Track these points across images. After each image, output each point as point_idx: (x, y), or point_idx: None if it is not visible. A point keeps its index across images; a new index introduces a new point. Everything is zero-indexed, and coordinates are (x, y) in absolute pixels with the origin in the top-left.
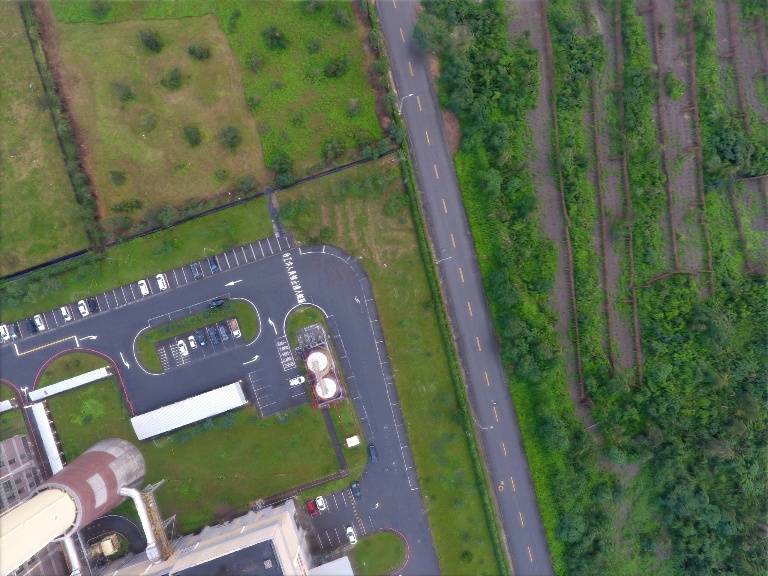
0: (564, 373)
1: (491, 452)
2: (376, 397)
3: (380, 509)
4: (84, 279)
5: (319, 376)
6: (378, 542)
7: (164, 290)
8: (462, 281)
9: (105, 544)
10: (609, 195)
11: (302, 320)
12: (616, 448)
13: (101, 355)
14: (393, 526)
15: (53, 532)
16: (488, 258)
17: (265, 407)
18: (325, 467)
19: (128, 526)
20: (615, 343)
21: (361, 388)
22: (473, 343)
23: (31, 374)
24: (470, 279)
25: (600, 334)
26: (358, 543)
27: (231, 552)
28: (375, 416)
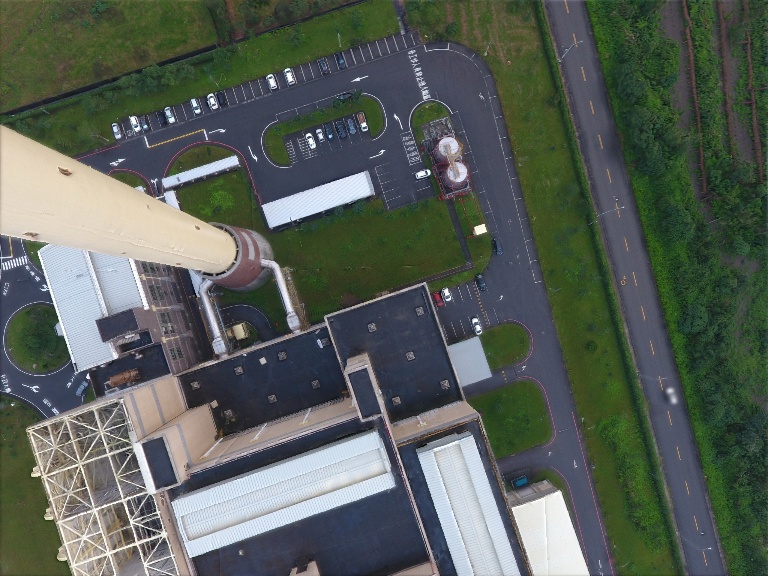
0: (686, 168)
1: (613, 247)
2: (500, 192)
3: (504, 301)
4: (214, 72)
5: (452, 158)
6: (503, 333)
7: (292, 85)
8: (584, 80)
9: (237, 328)
10: (726, 2)
11: (427, 115)
12: (741, 237)
13: (230, 148)
14: (517, 318)
15: (224, 253)
16: (610, 57)
17: (391, 200)
18: (450, 259)
19: (256, 315)
20: (734, 143)
21: (485, 183)
22: (595, 141)
23: (161, 166)
24: (592, 78)
25: (720, 132)
26: (483, 334)
27: (385, 297)
28: (499, 210)
